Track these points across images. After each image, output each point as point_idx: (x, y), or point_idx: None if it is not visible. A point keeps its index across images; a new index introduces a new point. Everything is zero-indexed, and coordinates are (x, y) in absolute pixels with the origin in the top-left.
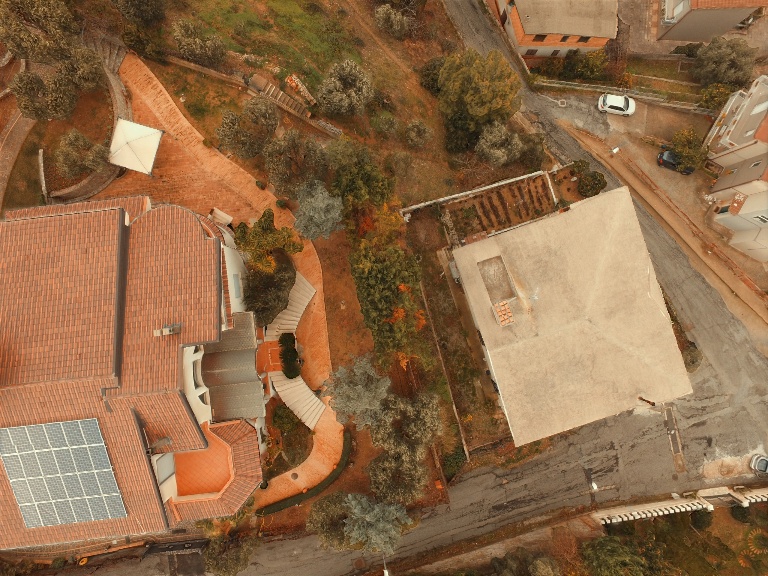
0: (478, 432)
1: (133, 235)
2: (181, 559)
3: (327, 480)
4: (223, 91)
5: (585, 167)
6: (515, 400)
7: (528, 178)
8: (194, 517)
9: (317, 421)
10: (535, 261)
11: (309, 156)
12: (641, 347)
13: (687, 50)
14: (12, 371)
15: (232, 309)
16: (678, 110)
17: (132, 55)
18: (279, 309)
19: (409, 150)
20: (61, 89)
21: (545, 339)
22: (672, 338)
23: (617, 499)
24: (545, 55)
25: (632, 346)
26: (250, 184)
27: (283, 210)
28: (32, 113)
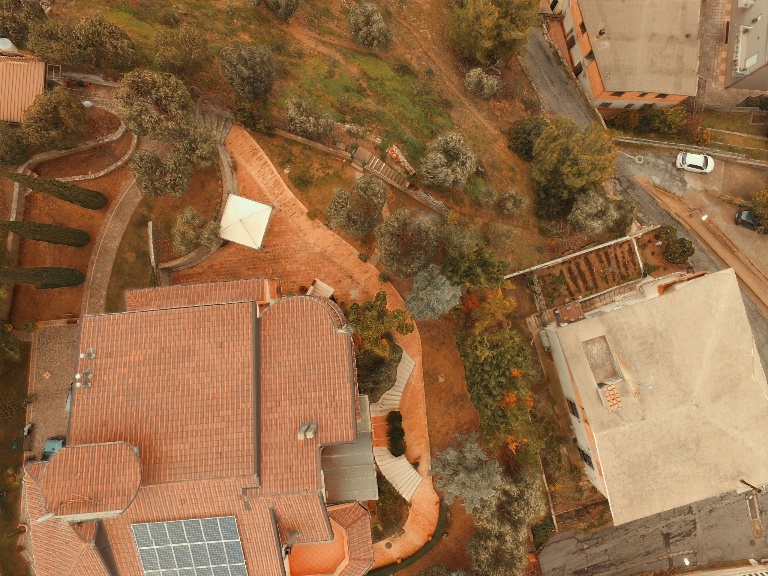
0: (562, 498)
1: (264, 327)
2: None
3: (422, 551)
4: (327, 163)
5: (673, 234)
6: (617, 481)
7: (615, 243)
8: None
9: (413, 492)
10: (640, 343)
11: (419, 235)
12: (745, 431)
13: (759, 102)
14: (154, 468)
15: None
16: (754, 167)
17: (238, 126)
18: (388, 388)
19: (501, 217)
20: (180, 169)
21: (651, 423)
22: None
23: (695, 564)
24: (618, 107)
25: (737, 430)
26: (352, 256)
27: (385, 283)
28: (151, 192)
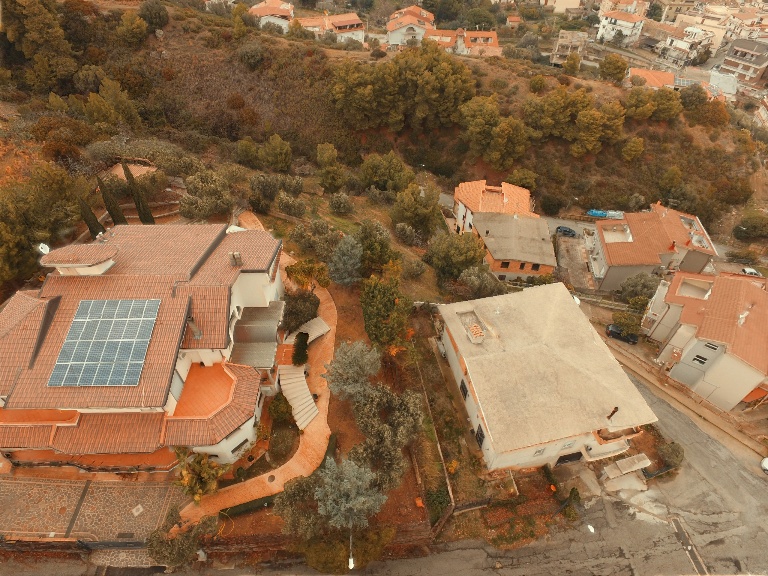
0: (465, 493)
1: (228, 237)
2: (110, 573)
3: None
4: None
5: None
6: (491, 404)
7: None
8: (177, 442)
9: (308, 424)
10: (500, 313)
11: None
12: (597, 374)
13: (616, 292)
14: (121, 269)
15: (271, 299)
16: None
17: (249, 211)
18: (302, 315)
19: (411, 279)
20: (208, 203)
21: (511, 355)
22: (624, 375)
23: None
24: None
25: (588, 371)
26: None
27: None
28: (186, 209)
